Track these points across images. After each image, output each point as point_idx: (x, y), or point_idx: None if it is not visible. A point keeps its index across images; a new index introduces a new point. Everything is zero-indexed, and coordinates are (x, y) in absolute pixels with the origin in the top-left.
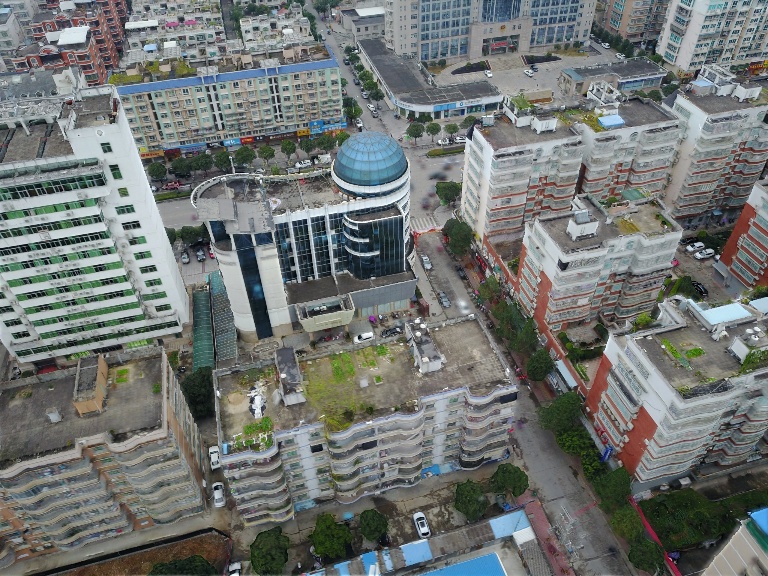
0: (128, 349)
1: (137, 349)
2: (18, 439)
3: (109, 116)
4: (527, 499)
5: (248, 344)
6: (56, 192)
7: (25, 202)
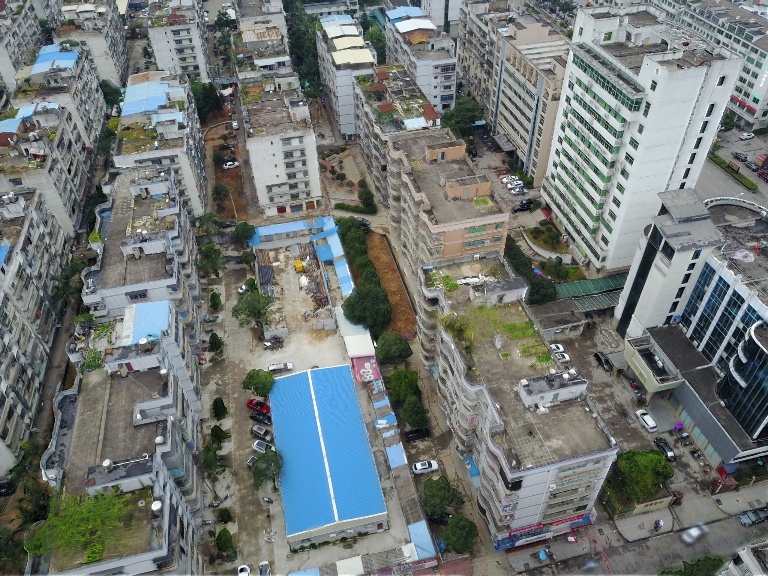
0: (575, 246)
1: (577, 252)
2: (427, 174)
3: (678, 65)
4: (458, 575)
5: (609, 324)
6: (611, 94)
7: (597, 88)
